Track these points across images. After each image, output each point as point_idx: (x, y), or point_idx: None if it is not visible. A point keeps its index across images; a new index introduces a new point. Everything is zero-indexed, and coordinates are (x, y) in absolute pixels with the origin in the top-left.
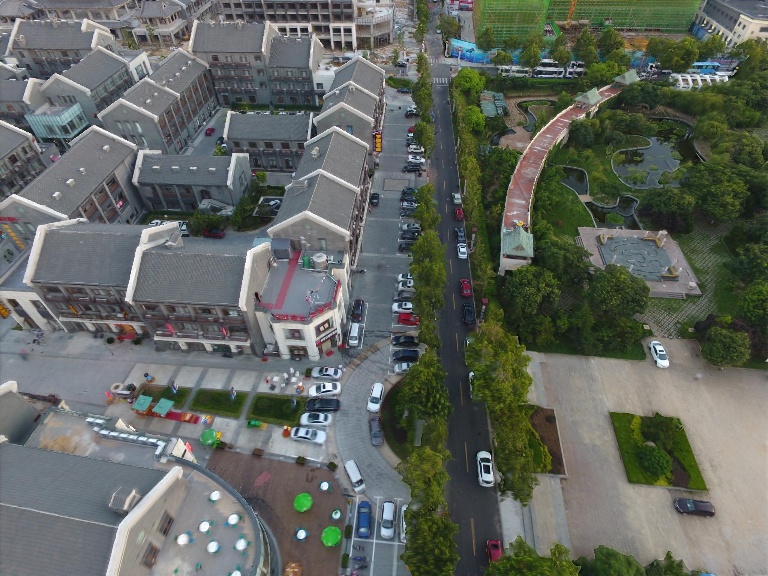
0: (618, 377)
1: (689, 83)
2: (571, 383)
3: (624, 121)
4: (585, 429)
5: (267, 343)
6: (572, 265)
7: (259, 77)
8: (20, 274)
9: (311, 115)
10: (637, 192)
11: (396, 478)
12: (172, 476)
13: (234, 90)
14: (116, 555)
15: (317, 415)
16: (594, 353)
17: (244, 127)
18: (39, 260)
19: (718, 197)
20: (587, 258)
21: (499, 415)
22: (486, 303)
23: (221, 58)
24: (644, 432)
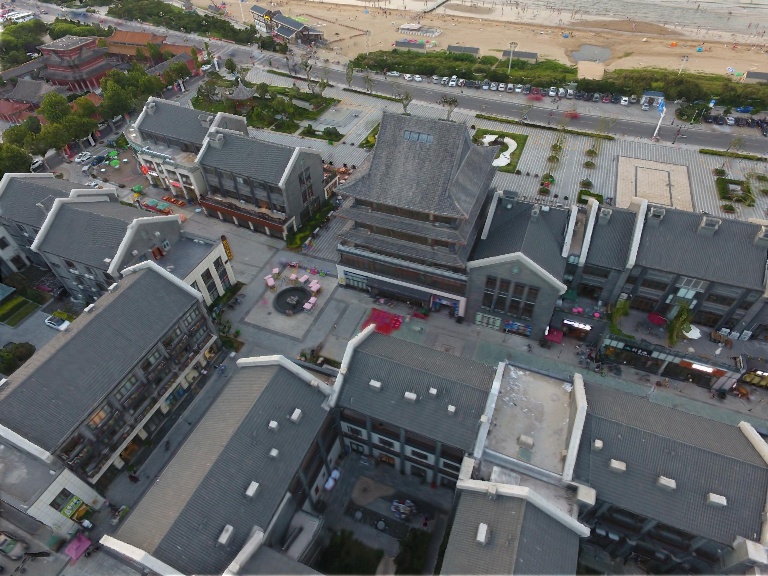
0: None
1: None
2: None
3: None
4: None
5: None
6: None
7: None
8: (198, 260)
9: None
10: None
11: None
12: (137, 121)
13: None
14: None
15: None
16: None
17: None
18: None
19: None
20: None
21: None
22: None
23: None
24: None
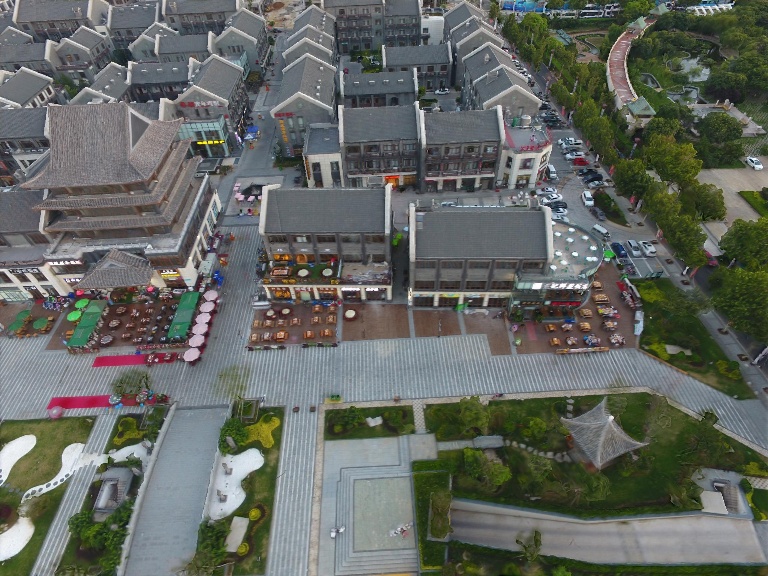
0: (733, 177)
1: (704, 12)
2: (706, 182)
3: (670, 38)
4: (726, 201)
5: (497, 180)
6: (685, 116)
7: (376, 26)
8: (313, 148)
9: (449, 43)
10: (695, 84)
11: (624, 233)
12: None
13: (354, 39)
14: (550, 221)
15: (558, 209)
16: (714, 166)
17: (397, 56)
18: (344, 128)
19: (760, 75)
20: (691, 113)
21: (688, 182)
22: (639, 140)
23: (347, 11)
24: (764, 197)
